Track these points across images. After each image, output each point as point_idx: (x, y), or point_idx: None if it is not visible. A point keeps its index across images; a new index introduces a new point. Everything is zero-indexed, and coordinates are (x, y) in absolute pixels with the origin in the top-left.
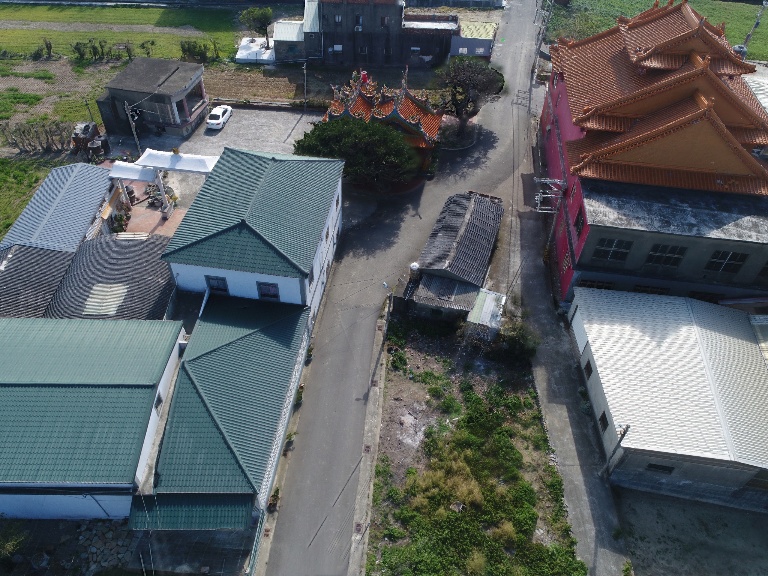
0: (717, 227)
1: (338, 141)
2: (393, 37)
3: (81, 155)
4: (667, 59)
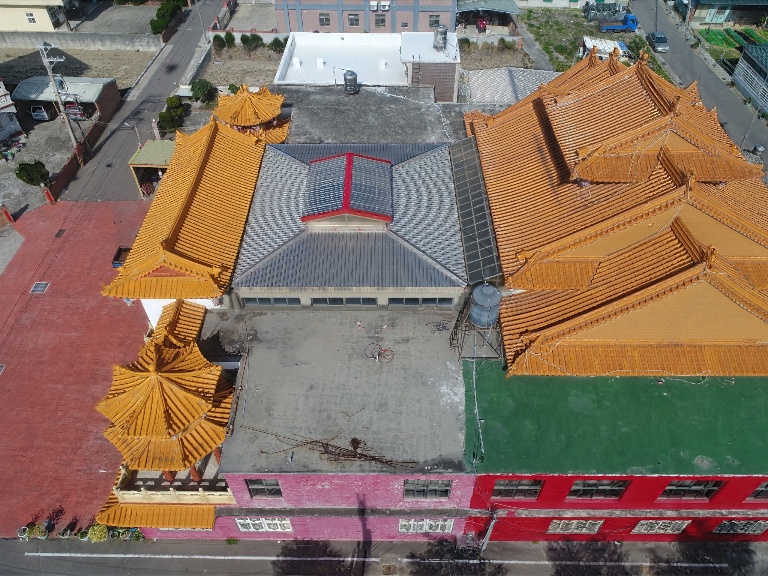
0: None
1: None
2: None
3: None
4: None
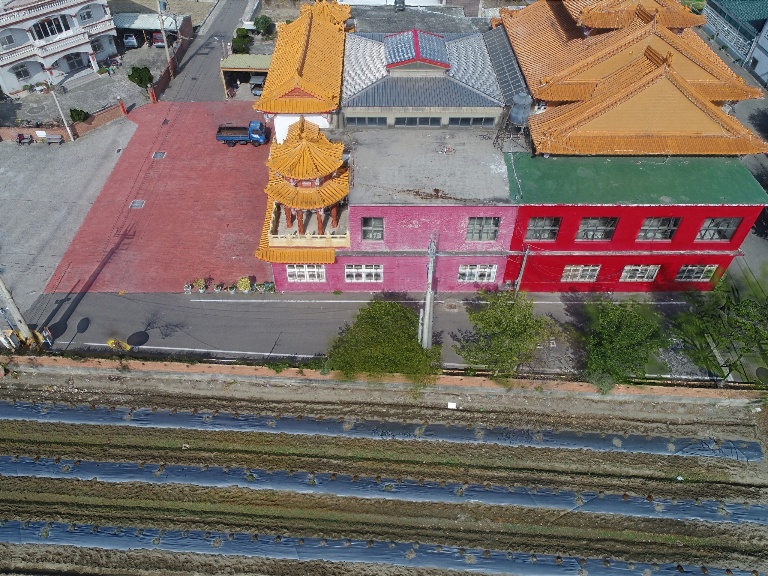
0: None
1: None
2: None
3: None
4: None
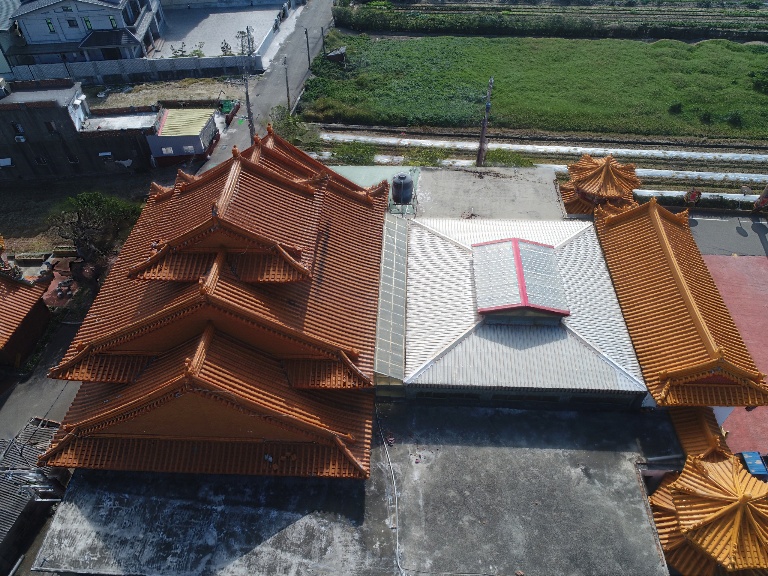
0: (243, 551)
1: None
2: (71, 143)
3: None
4: (187, 262)
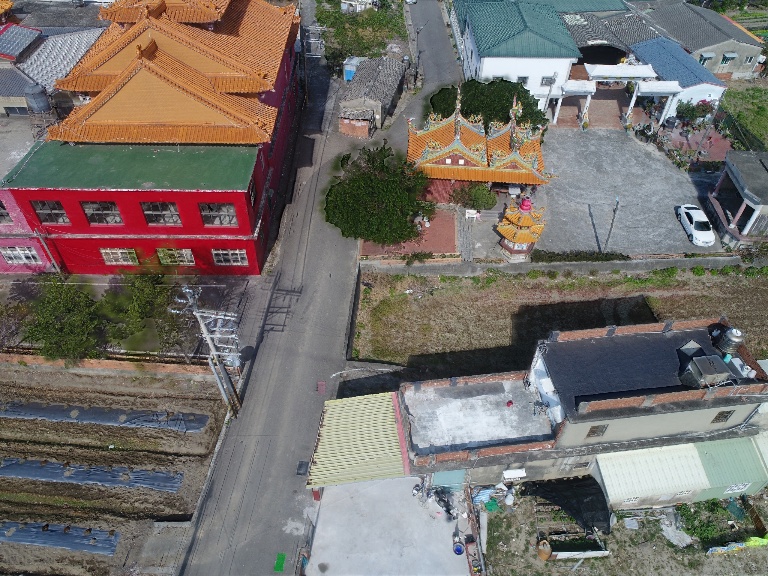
0: None
1: None
2: None
3: (760, 145)
4: None
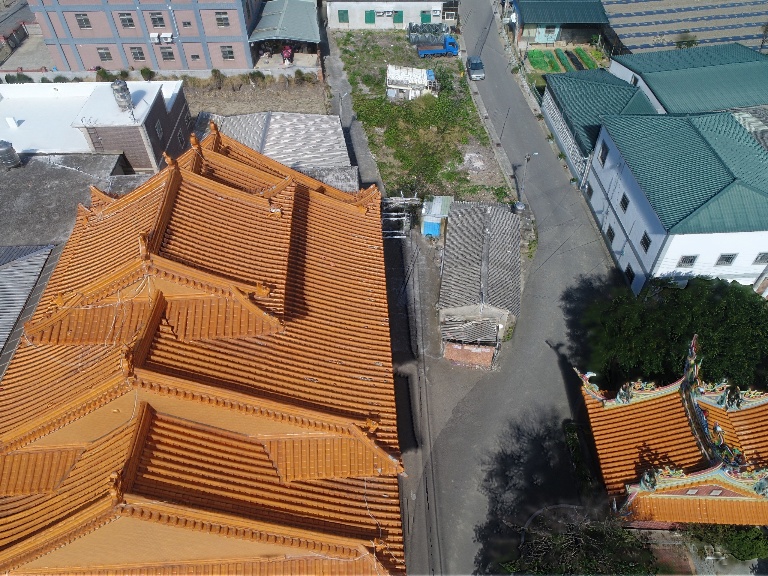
0: None
1: (717, 293)
2: None
3: None
4: None
